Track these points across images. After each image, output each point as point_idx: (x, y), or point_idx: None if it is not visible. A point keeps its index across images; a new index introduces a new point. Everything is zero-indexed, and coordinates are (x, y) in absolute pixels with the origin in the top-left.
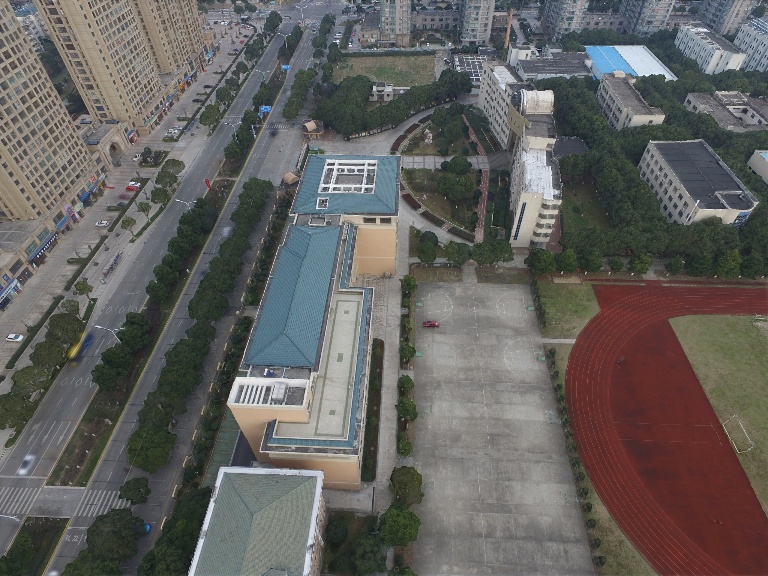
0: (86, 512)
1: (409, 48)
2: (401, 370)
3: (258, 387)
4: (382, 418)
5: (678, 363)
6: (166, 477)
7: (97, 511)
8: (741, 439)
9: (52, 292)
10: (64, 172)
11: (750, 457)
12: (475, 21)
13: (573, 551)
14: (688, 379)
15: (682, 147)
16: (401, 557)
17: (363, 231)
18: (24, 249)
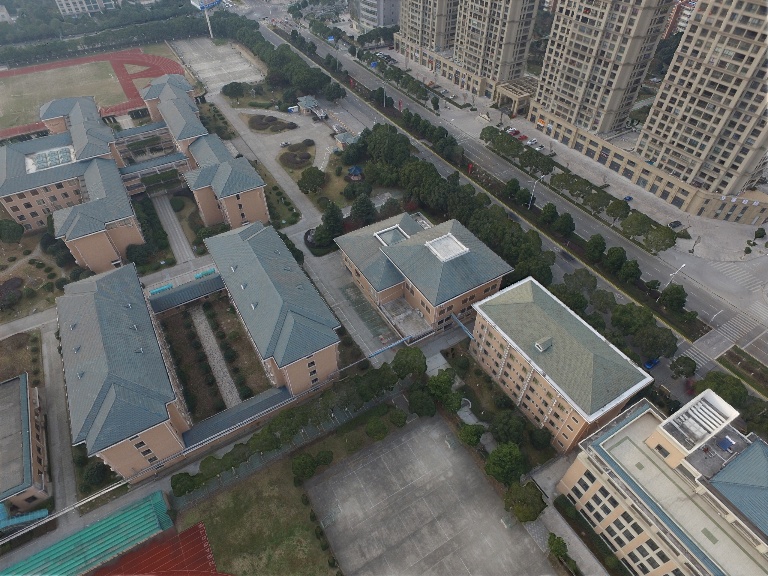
0: (691, 351)
1: None
2: None
3: (715, 426)
4: None
5: None
6: (686, 398)
7: (687, 355)
8: None
9: None
10: None
11: None
12: None
13: (357, 559)
14: None
15: None
16: (485, 455)
17: None
18: None
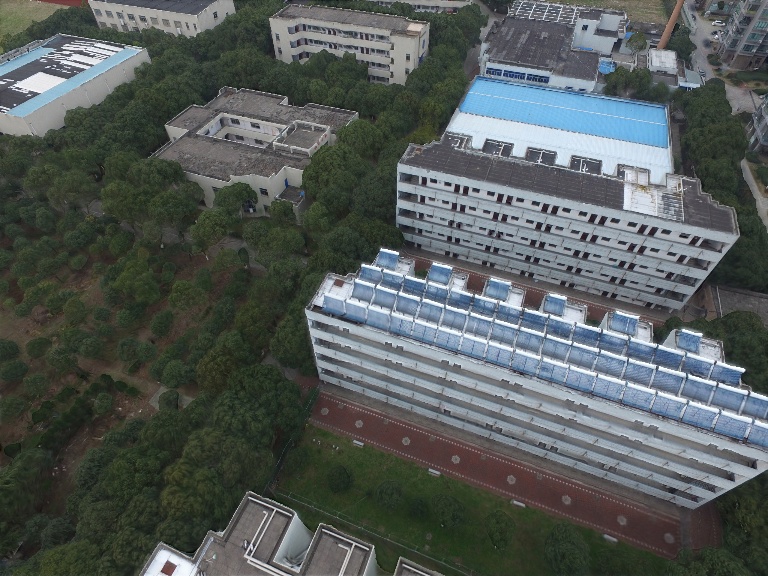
0: None
1: (686, 6)
2: None
3: None
4: None
5: (80, 4)
6: None
7: None
8: (29, 2)
9: None
10: None
11: (22, 1)
12: (743, 3)
13: None
14: (70, 3)
15: (202, 5)
16: None
17: None
18: None
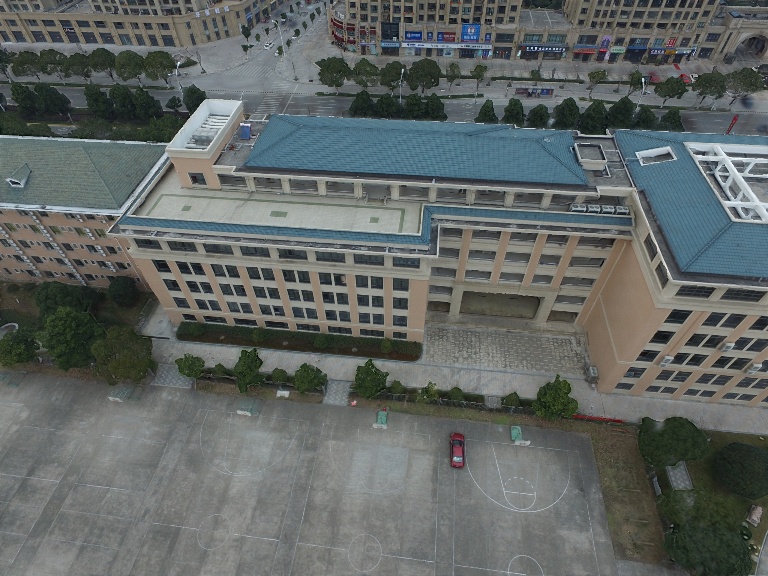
0: None
1: None
2: (350, 384)
3: None
4: (266, 352)
5: None
6: None
7: None
8: None
9: (488, 73)
10: (652, 7)
11: None
12: None
13: None
14: None
15: None
16: None
17: (631, 256)
18: (527, 32)
